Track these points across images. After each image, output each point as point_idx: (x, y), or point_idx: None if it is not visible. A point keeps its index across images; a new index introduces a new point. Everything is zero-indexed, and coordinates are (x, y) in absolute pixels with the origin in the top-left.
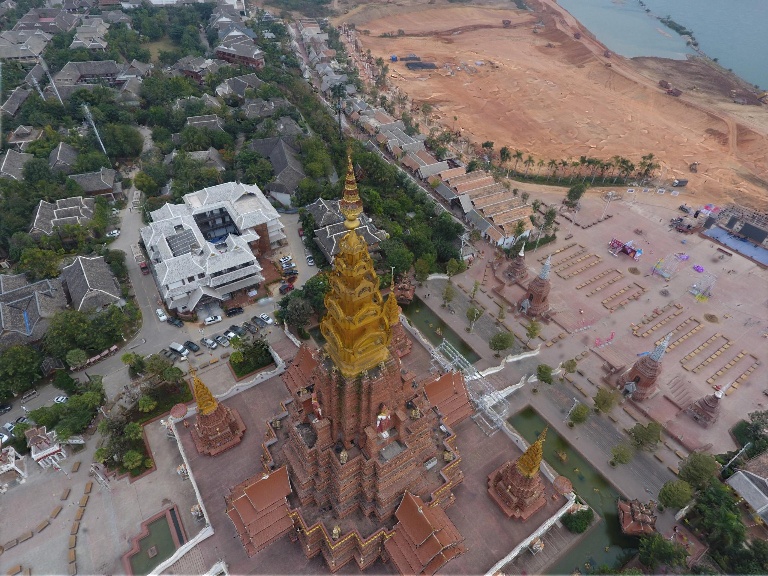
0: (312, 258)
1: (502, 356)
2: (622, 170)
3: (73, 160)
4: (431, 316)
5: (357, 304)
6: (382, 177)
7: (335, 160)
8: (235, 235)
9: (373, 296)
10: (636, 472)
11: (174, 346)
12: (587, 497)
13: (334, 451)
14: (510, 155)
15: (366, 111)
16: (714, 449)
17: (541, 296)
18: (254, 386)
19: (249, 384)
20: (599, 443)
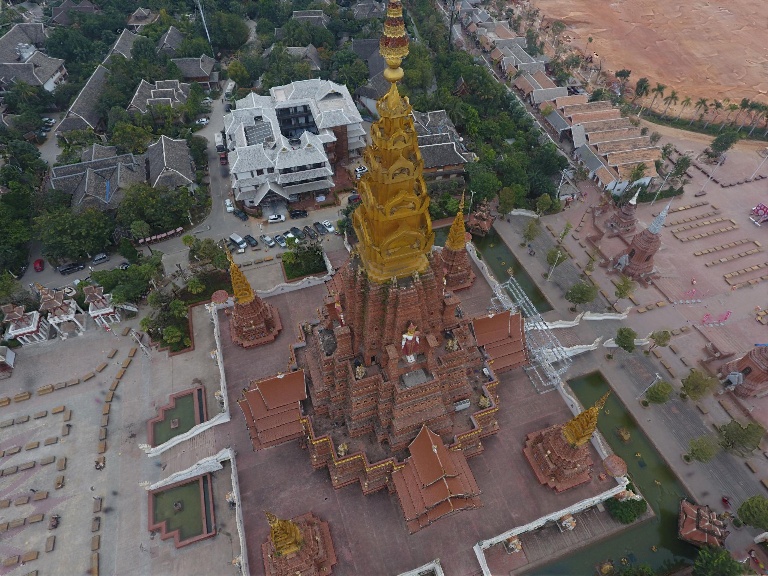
0: None
1: (579, 311)
2: None
3: (179, 45)
4: (506, 253)
5: (391, 190)
6: (486, 94)
7: (438, 71)
8: (311, 133)
9: (417, 188)
10: (716, 476)
11: (234, 237)
12: (644, 487)
13: (352, 364)
14: (648, 88)
15: (486, 23)
16: None
17: (645, 253)
18: (300, 289)
19: (295, 286)
20: (676, 432)
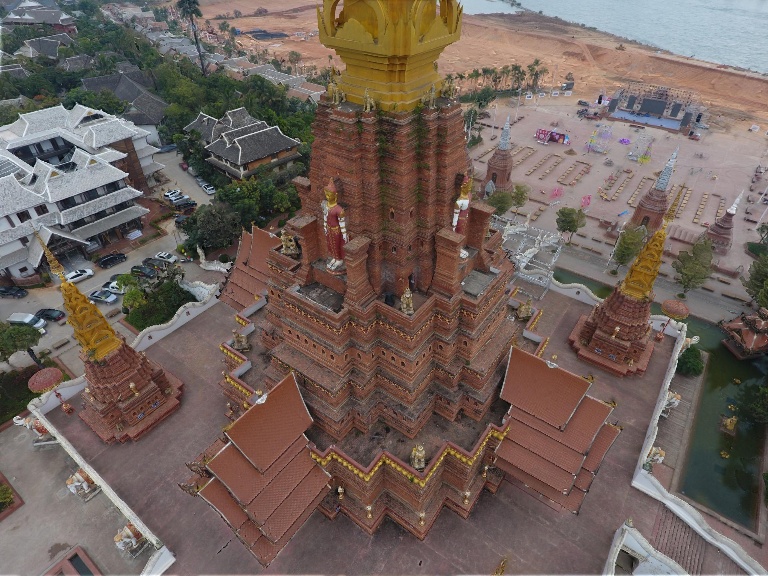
0: (211, 185)
1: None
2: (514, 80)
3: None
4: None
5: None
6: (272, 97)
7: None
8: (86, 152)
9: None
10: (706, 301)
11: (16, 317)
12: None
13: None
14: None
15: (225, 61)
16: (745, 270)
17: (506, 172)
18: (177, 329)
19: (168, 326)
20: None
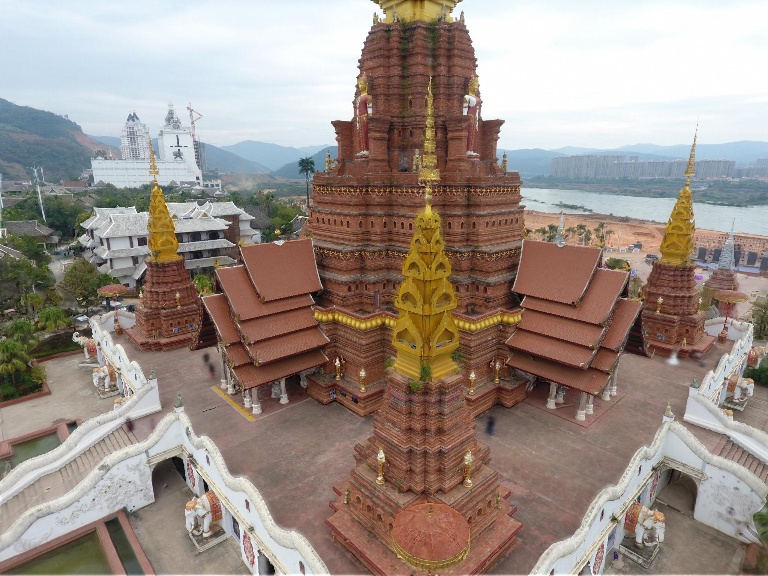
0: None
1: None
2: None
3: None
4: None
5: None
6: None
7: None
8: None
9: None
10: None
11: None
12: None
13: None
14: None
15: None
16: None
17: None
18: None
19: None
20: None
